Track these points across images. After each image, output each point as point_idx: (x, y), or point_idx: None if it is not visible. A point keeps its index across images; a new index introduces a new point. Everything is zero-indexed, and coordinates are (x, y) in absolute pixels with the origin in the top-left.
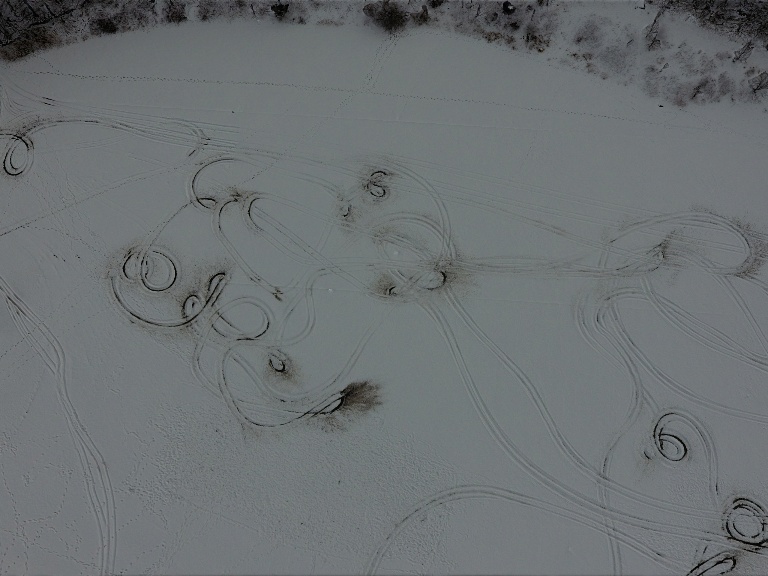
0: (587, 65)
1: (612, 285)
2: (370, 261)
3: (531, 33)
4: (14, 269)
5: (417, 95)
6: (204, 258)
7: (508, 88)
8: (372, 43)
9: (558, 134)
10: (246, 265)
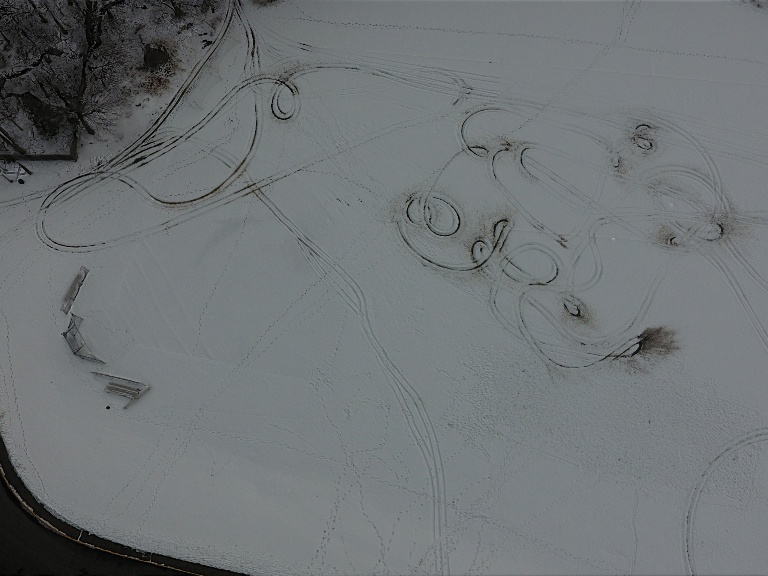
0: None
1: None
2: (647, 212)
3: None
4: (300, 211)
5: (669, 50)
6: (485, 205)
7: (758, 46)
8: None
9: None
10: (527, 213)
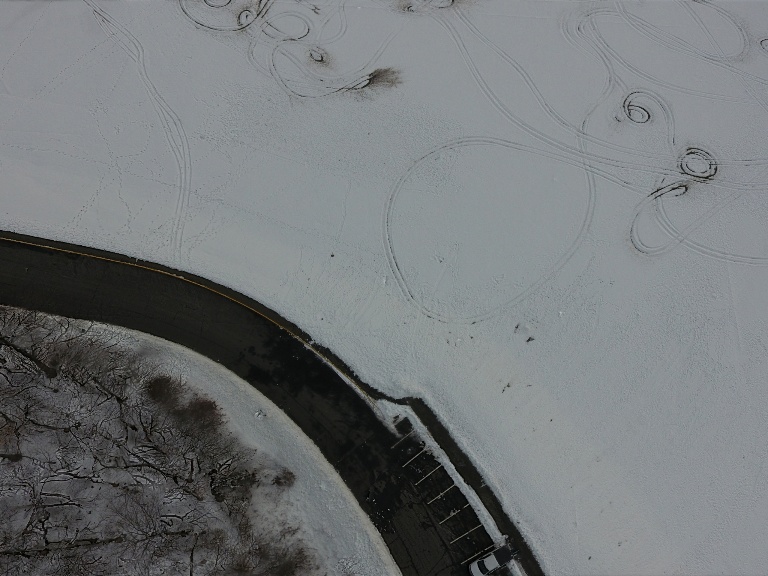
0: None
1: (591, 6)
2: None
3: None
4: None
5: None
6: None
7: None
8: None
9: None
10: None
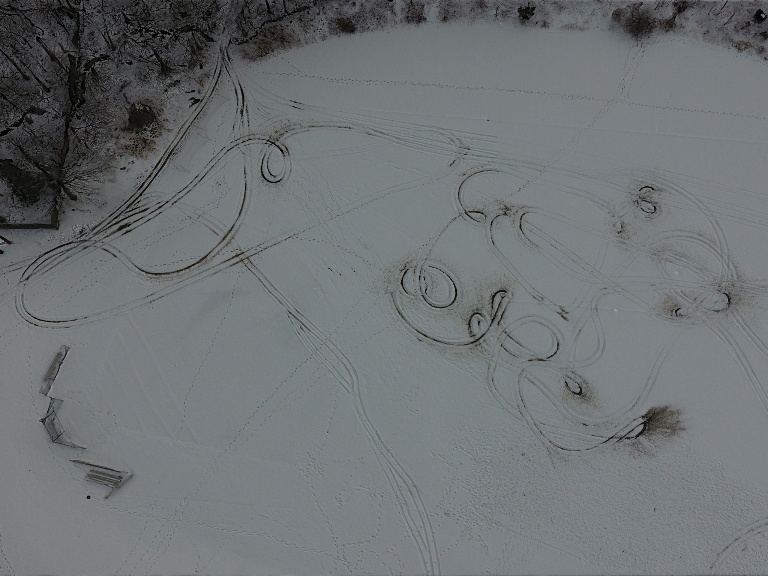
0: None
1: None
2: (652, 281)
3: None
4: (290, 282)
5: (673, 106)
6: (482, 274)
7: (765, 101)
8: (619, 50)
9: None
10: (526, 282)
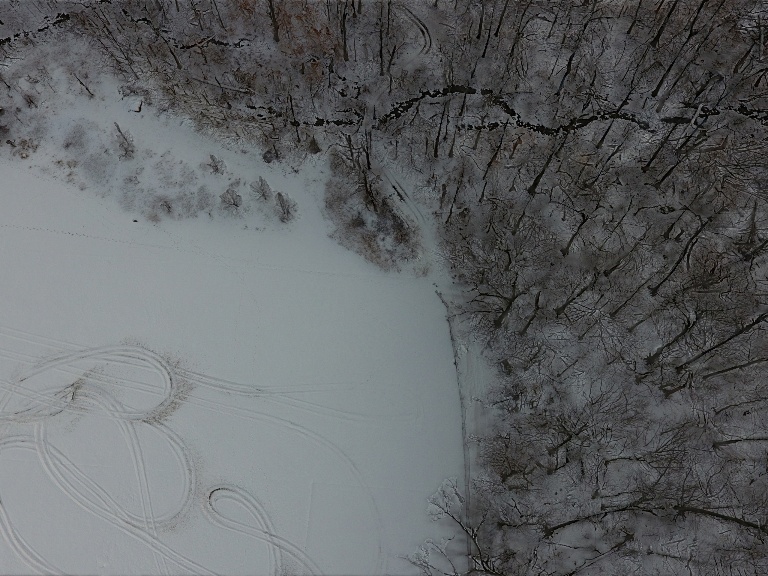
0: (68, 174)
1: (2, 432)
2: None
3: (22, 137)
4: None
5: None
6: None
7: None
8: None
9: (9, 254)
10: None
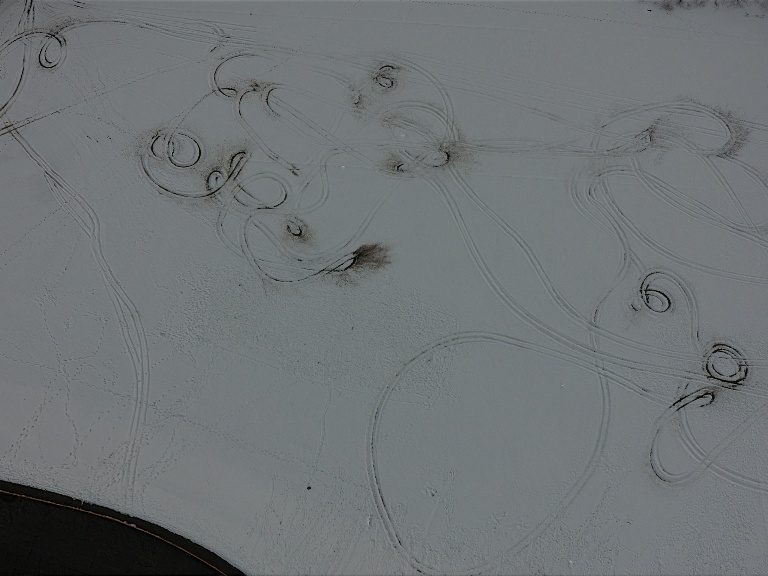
0: None
1: (603, 163)
2: (379, 142)
3: None
4: (51, 148)
5: None
6: (226, 139)
7: None
8: None
9: (553, 34)
10: (265, 145)
